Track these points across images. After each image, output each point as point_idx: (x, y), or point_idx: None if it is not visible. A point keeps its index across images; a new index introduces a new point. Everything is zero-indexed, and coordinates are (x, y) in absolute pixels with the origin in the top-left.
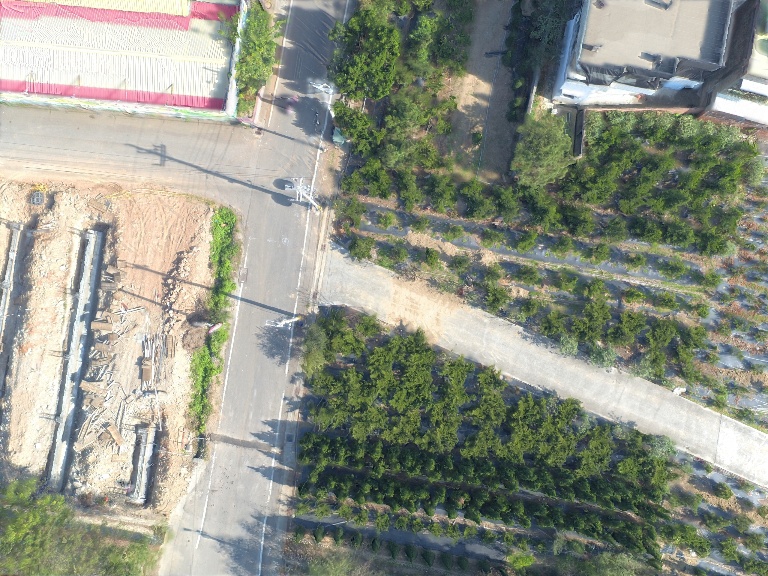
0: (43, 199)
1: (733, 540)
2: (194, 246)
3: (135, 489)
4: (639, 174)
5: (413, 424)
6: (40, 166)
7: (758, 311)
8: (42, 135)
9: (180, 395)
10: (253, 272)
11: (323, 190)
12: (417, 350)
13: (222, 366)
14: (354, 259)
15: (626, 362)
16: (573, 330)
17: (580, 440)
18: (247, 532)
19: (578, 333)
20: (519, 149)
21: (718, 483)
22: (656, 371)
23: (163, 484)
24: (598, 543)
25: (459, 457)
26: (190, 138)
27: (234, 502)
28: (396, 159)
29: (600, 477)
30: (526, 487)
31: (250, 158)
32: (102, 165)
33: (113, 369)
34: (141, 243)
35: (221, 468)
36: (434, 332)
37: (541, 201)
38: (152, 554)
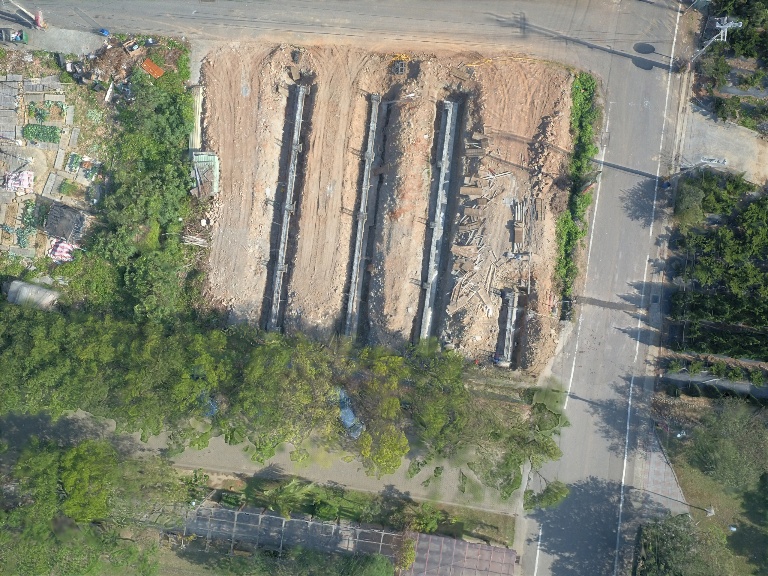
0: (405, 69)
1: None
2: (558, 111)
3: (504, 351)
4: None
5: None
6: (401, 37)
7: None
8: (402, 6)
9: (547, 258)
10: (615, 136)
11: (683, 53)
12: None
13: (586, 230)
14: (717, 120)
15: None
16: None
17: None
18: (615, 392)
19: None
20: None
21: None
22: None
23: (534, 345)
24: None
25: None
26: (549, 5)
27: (601, 363)
28: (764, 17)
29: None
30: None
31: (609, 23)
32: (462, 34)
33: (483, 233)
34: (506, 109)
35: (588, 330)
36: None
37: None
38: None
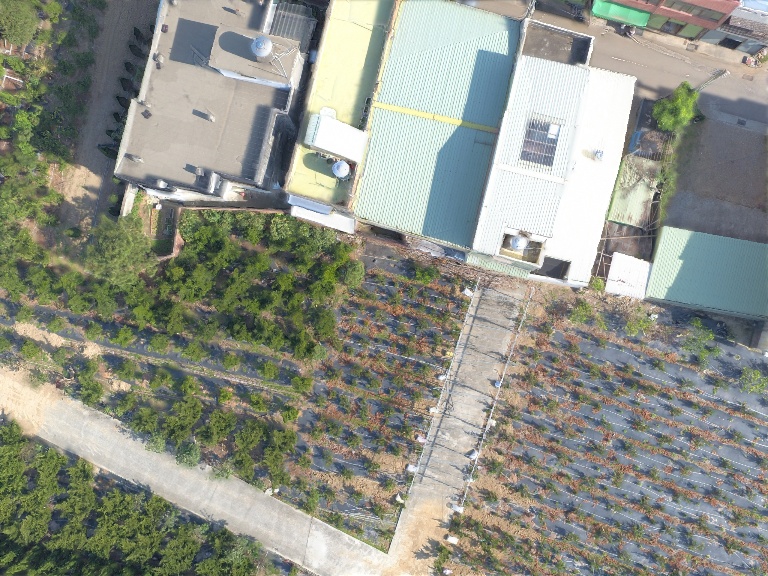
0: None
1: None
2: None
3: None
4: None
5: (2, 514)
6: None
7: (355, 414)
8: None
9: None
10: None
11: None
12: (9, 441)
13: None
14: None
15: (220, 460)
16: (164, 427)
17: None
18: None
19: (169, 431)
20: (90, 251)
21: None
22: (238, 473)
23: None
24: None
25: None
26: None
27: None
28: None
29: (189, 574)
30: None
31: None
32: None
33: None
34: None
35: None
36: (34, 422)
37: (131, 299)
38: None
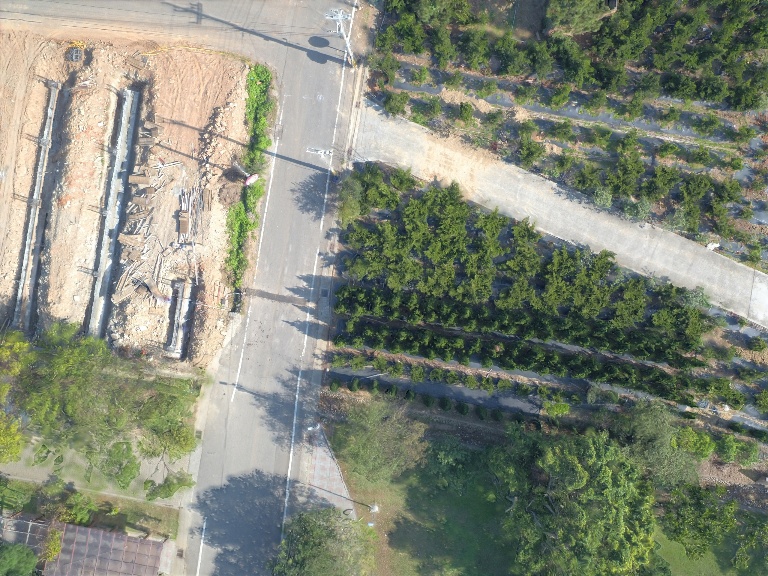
0: (81, 56)
1: (766, 392)
2: (230, 102)
3: (172, 342)
4: (674, 27)
5: (447, 275)
6: (78, 24)
7: None
8: None
9: (216, 249)
10: (288, 129)
11: (358, 48)
12: (451, 203)
13: (257, 222)
14: (389, 116)
15: (659, 218)
16: (607, 184)
17: (613, 294)
18: (282, 385)
19: (612, 187)
20: None
21: (751, 337)
22: (690, 222)
23: (199, 336)
24: (631, 397)
25: (493, 310)
26: None
27: (269, 356)
28: (431, 14)
29: None
30: (559, 339)
31: (286, 16)
32: (139, 23)
33: (150, 222)
34: (178, 99)
35: (256, 322)
36: (468, 187)
37: (576, 54)
38: (189, 402)
